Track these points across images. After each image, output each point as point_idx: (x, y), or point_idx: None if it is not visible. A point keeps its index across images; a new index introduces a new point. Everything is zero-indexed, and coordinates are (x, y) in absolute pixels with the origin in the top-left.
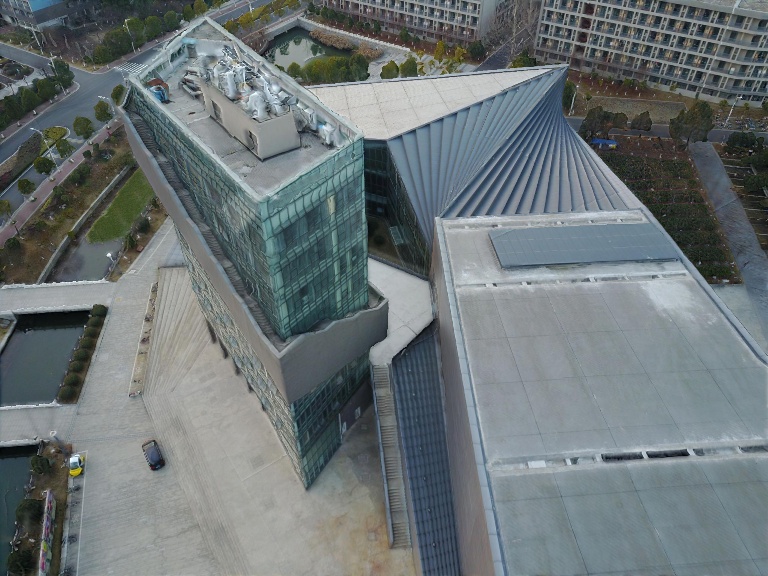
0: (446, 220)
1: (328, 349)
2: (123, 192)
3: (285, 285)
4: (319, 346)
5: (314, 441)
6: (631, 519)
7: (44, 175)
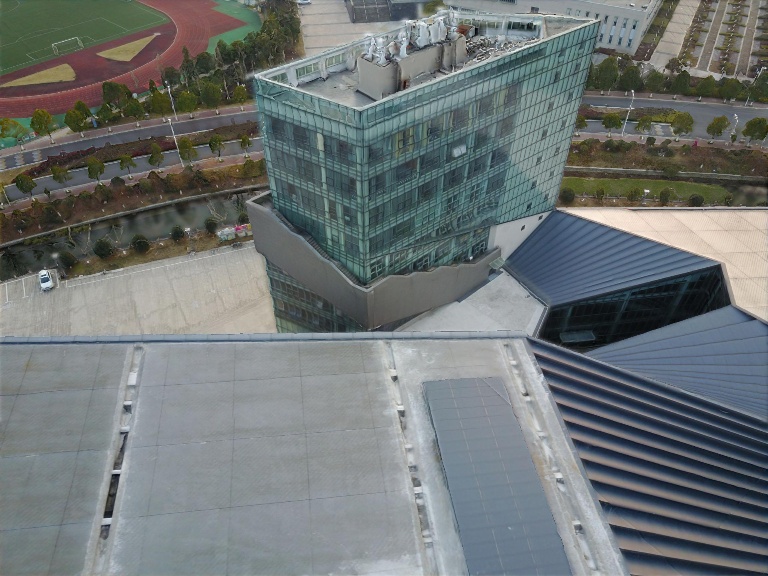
0: (522, 342)
1: (293, 252)
2: (625, 181)
3: (274, 163)
4: (284, 238)
5: (290, 320)
6: (51, 438)
7: (612, 131)
